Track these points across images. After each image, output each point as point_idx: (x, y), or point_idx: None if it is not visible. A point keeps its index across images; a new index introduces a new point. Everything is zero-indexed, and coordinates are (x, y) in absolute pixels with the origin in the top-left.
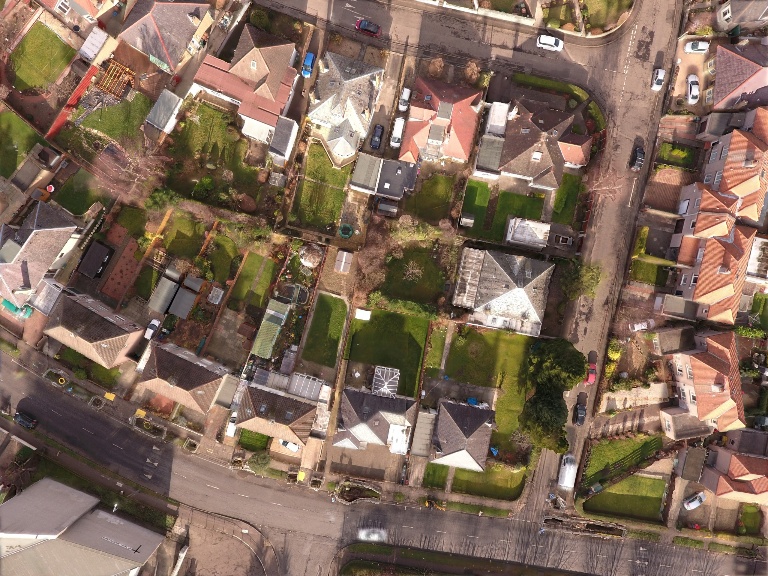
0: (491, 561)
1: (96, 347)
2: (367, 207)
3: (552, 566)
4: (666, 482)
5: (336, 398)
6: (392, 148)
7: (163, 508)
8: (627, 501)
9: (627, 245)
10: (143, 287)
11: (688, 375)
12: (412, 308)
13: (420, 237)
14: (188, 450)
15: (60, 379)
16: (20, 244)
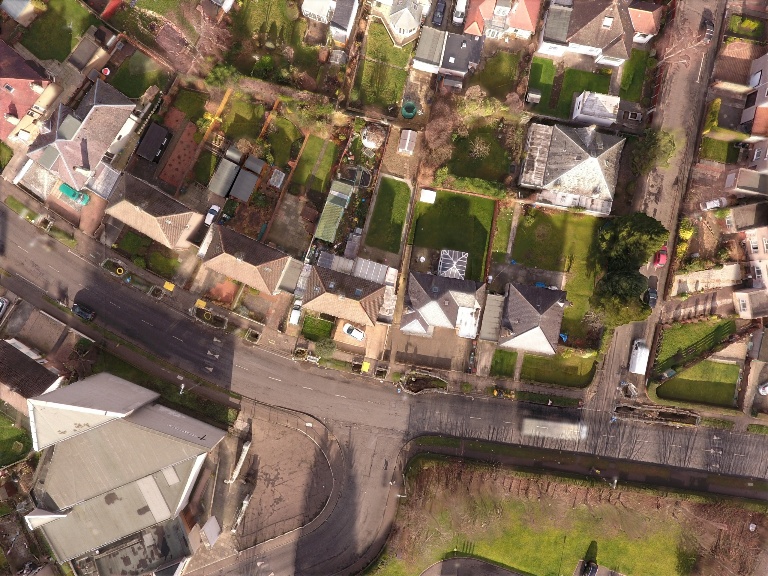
0: (561, 452)
1: (161, 222)
2: (430, 86)
3: (624, 457)
4: (740, 367)
5: (401, 285)
6: (454, 25)
7: (225, 401)
8: (700, 388)
9: (696, 122)
10: (202, 172)
11: (765, 249)
12: (480, 185)
13: (487, 111)
14: (250, 341)
15: (118, 269)
16: (80, 121)
